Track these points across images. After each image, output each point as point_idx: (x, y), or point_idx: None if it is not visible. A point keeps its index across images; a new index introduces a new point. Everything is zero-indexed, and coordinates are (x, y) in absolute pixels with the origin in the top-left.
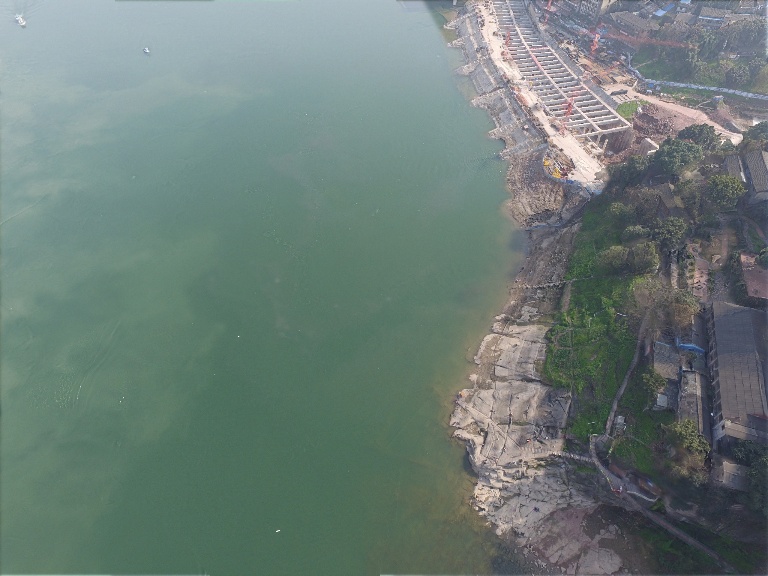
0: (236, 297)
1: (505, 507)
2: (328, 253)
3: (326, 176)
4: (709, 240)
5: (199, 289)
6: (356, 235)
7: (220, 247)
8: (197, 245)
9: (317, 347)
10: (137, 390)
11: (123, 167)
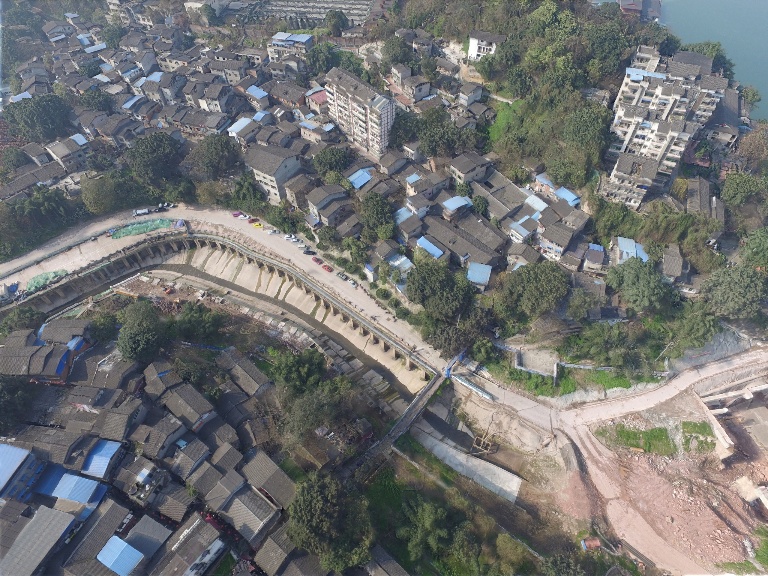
0: None
1: None
2: None
3: None
4: (719, 194)
5: None
6: None
7: None
8: None
9: None
10: None
11: None
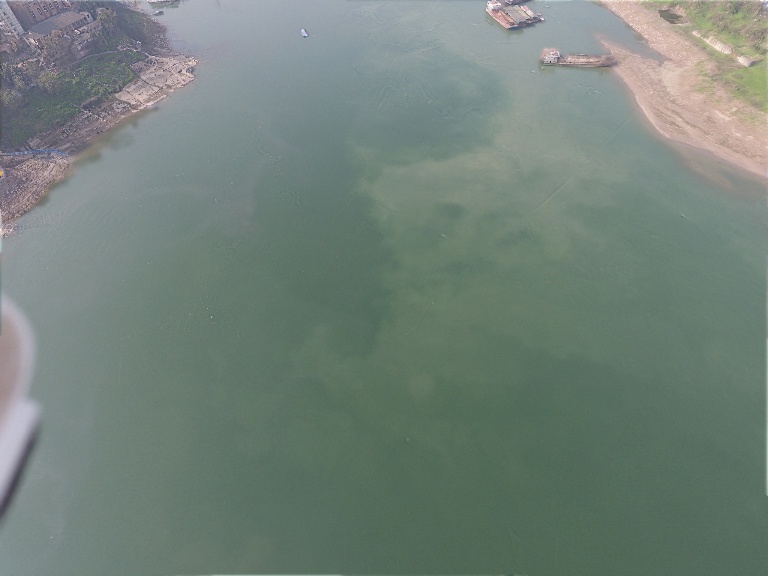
0: (303, 123)
1: None
2: (231, 144)
3: (214, 214)
4: None
5: (330, 127)
6: (205, 157)
7: (320, 153)
8: (342, 159)
9: (251, 101)
10: (353, 87)
11: (466, 249)
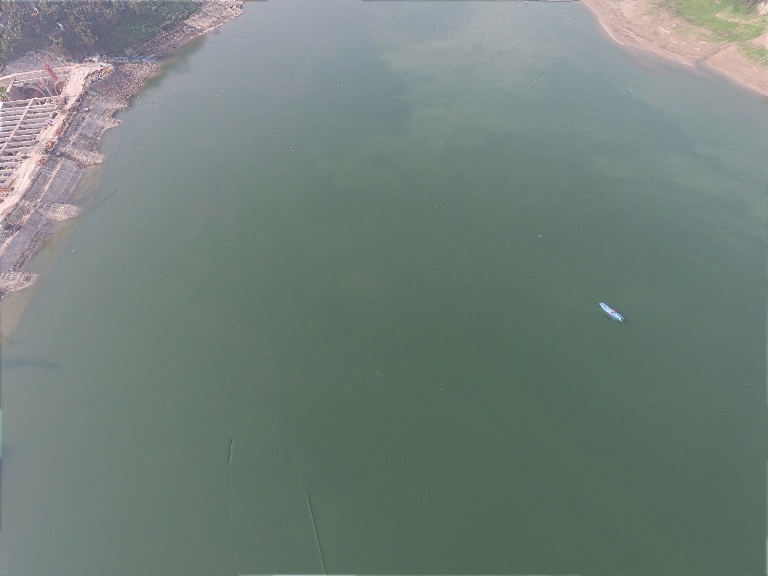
0: (337, 39)
1: (234, 0)
2: (284, 53)
3: (279, 94)
4: None
5: (360, 41)
6: (264, 61)
7: (354, 58)
8: (371, 62)
9: (294, 26)
10: (375, 16)
11: None
